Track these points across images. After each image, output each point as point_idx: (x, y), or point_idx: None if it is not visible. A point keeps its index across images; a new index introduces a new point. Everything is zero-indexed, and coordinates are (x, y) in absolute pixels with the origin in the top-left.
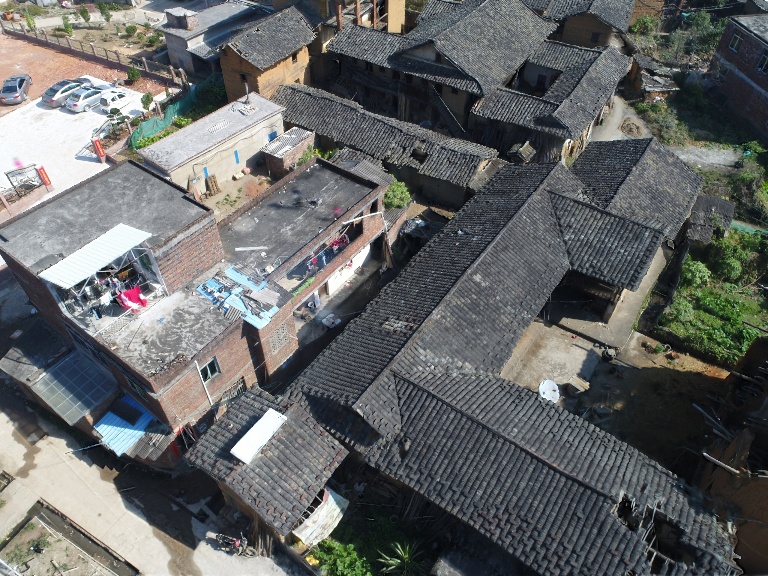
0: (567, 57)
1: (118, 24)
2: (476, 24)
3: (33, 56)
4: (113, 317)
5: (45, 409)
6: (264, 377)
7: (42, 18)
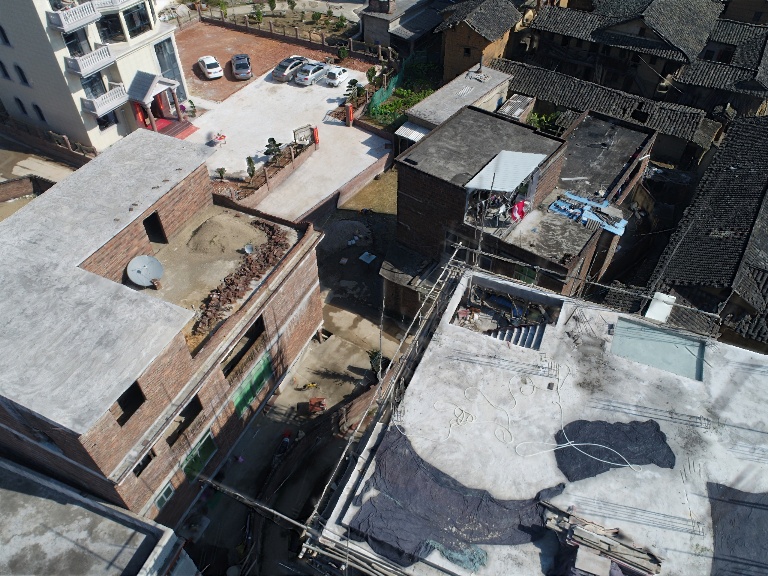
0: (739, 33)
1: (297, 12)
2: (665, 3)
3: (238, 40)
4: (494, 228)
5: (401, 315)
6: (588, 286)
7: None
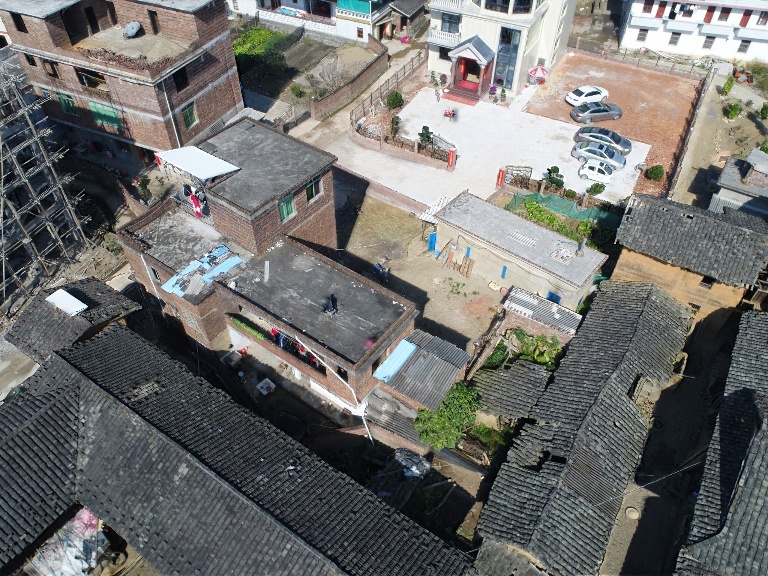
0: None
1: None
2: None
3: (669, 107)
4: None
5: None
6: None
7: (758, 93)
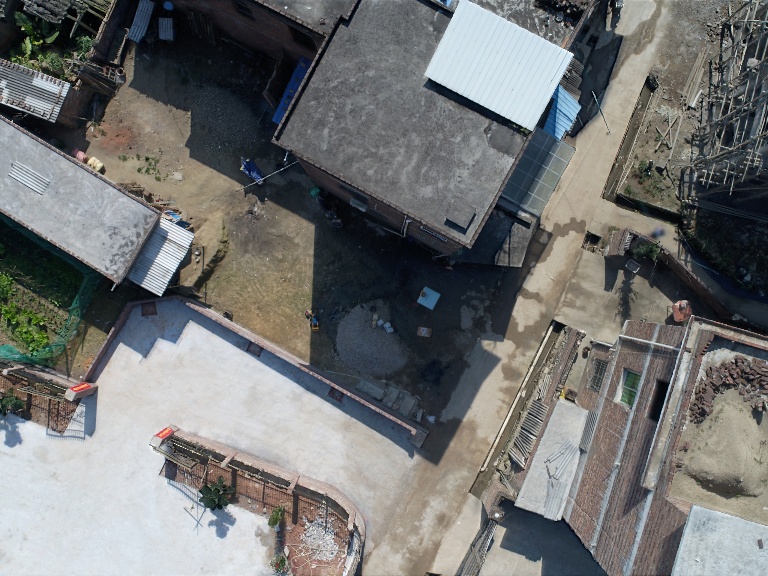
0: None
1: None
2: None
3: None
4: None
5: None
6: None
7: None
